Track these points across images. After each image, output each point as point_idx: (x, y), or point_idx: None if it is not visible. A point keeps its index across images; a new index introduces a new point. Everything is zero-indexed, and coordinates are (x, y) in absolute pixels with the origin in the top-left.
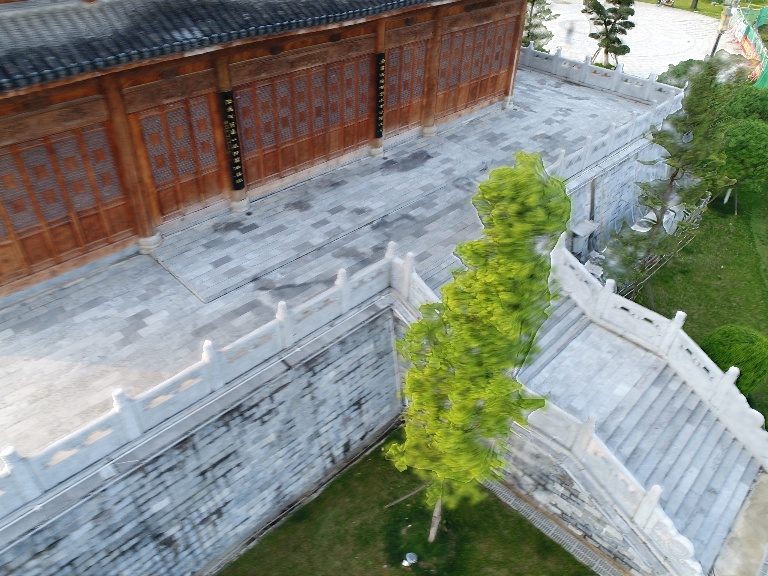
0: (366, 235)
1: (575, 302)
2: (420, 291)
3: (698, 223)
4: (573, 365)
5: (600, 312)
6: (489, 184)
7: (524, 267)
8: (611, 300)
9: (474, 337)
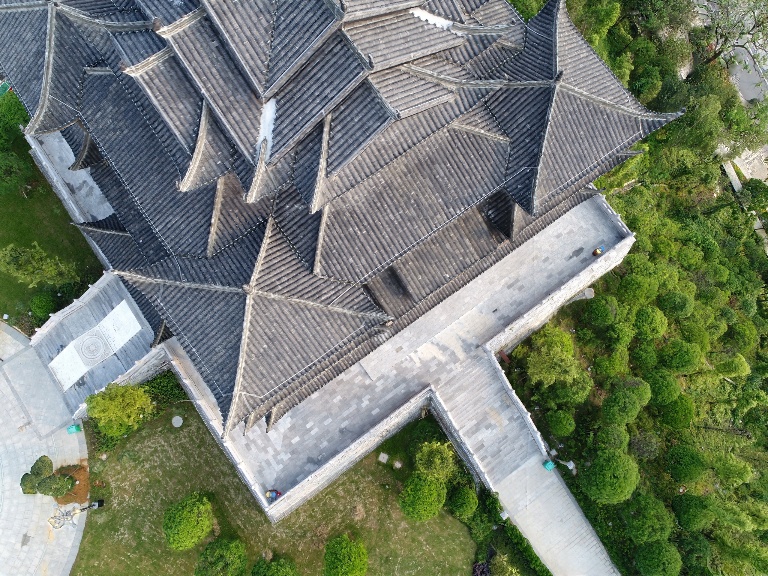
0: None
1: None
2: None
3: None
4: None
5: None
6: None
7: None
8: None
9: None
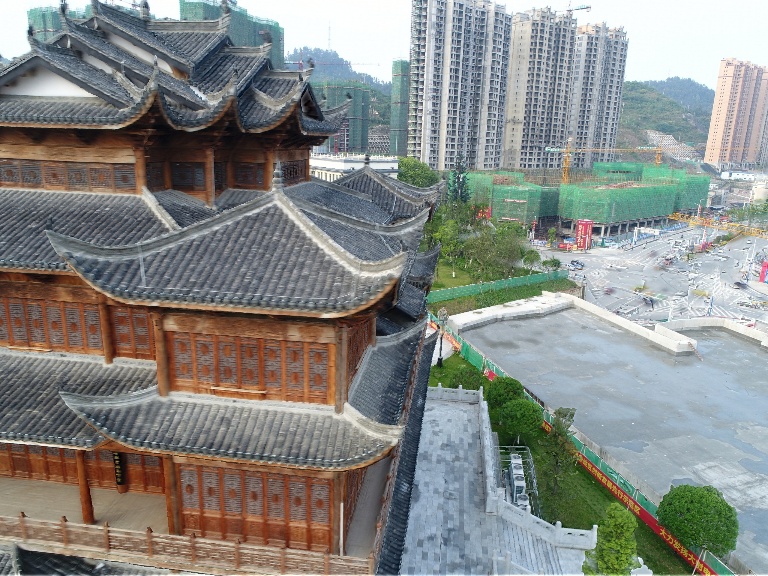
0: (448, 551)
1: (545, 540)
2: (517, 570)
3: (526, 464)
4: (571, 574)
5: (558, 540)
6: (622, 520)
7: (635, 543)
8: (562, 532)
9: (625, 575)
